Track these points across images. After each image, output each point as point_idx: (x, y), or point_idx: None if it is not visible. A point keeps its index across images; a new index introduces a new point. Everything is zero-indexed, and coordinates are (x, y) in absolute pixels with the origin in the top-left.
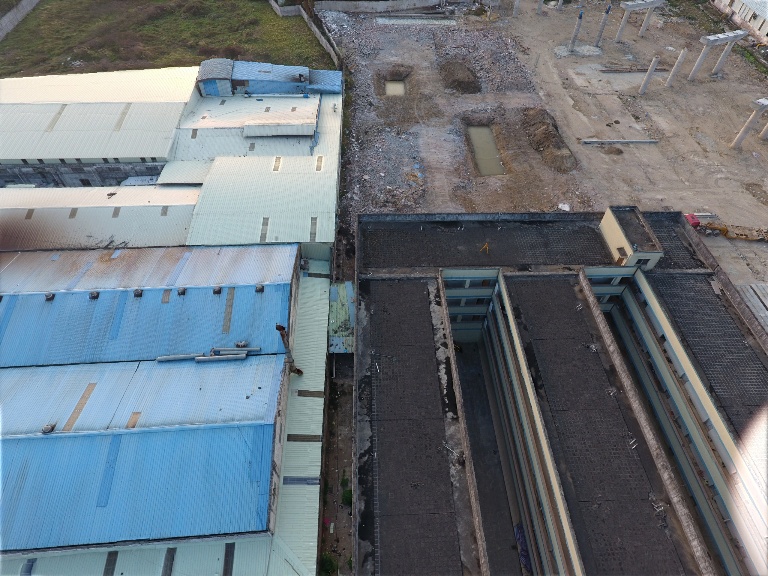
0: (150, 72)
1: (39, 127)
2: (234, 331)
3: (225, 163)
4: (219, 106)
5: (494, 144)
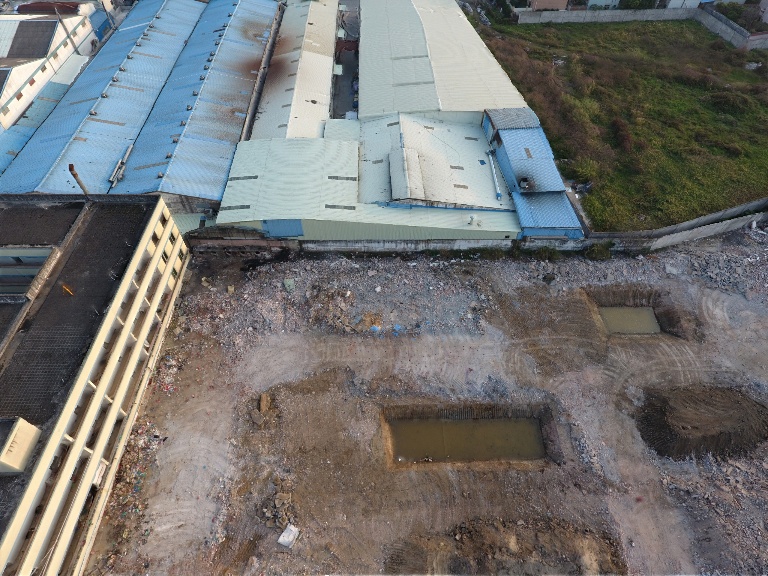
0: (504, 85)
1: (395, 54)
2: (134, 172)
3: (345, 147)
4: (460, 136)
5: (487, 457)
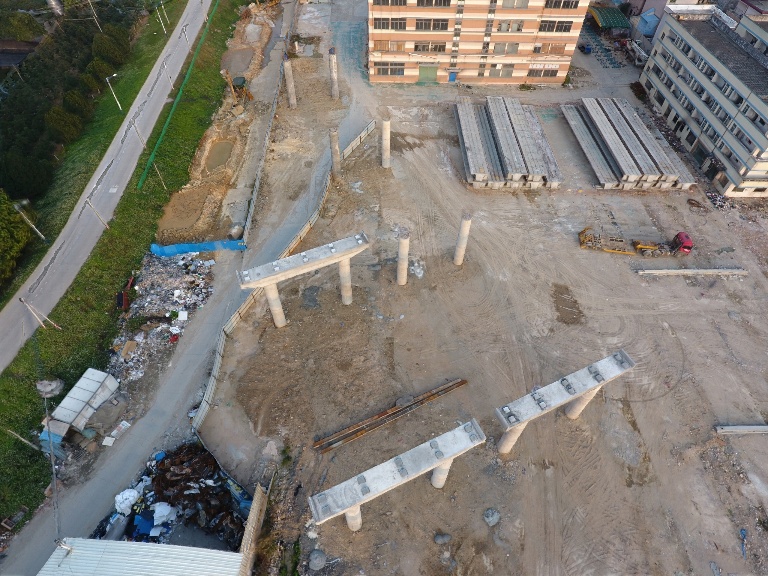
0: None
1: None
2: None
3: None
4: None
5: None
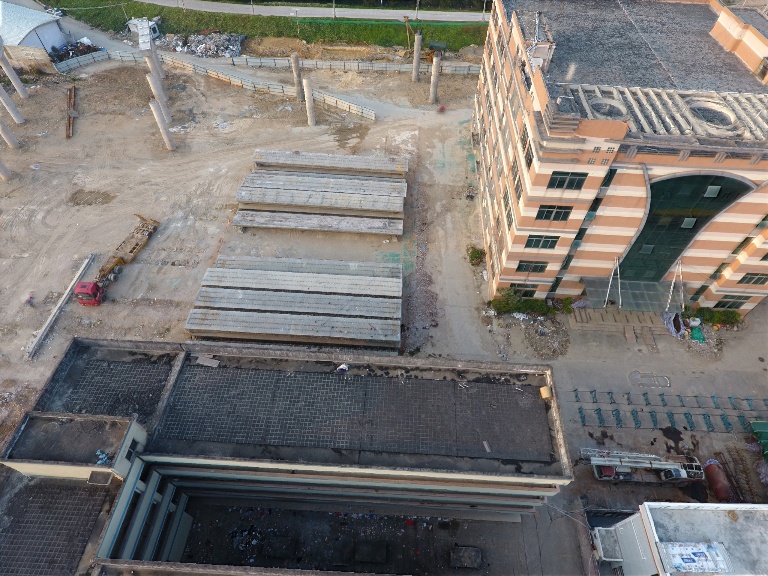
0: None
1: None
2: None
3: None
4: None
5: None
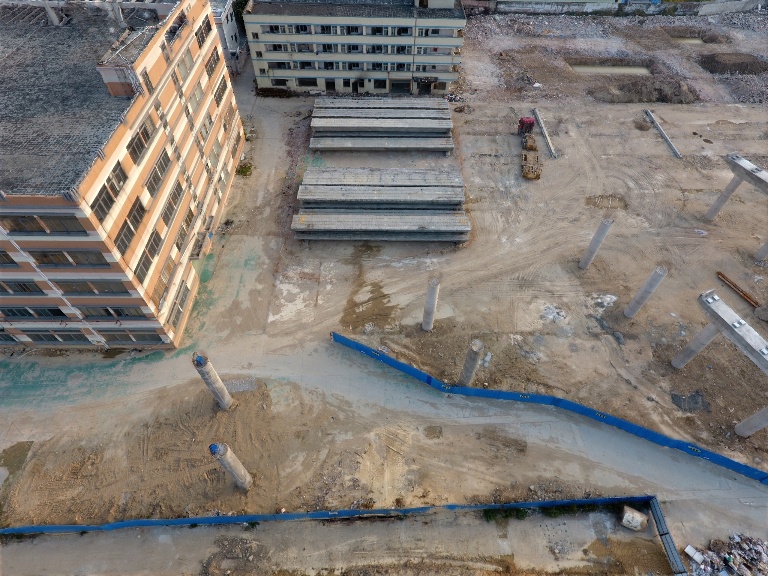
0: None
1: None
2: None
3: None
4: None
5: None
